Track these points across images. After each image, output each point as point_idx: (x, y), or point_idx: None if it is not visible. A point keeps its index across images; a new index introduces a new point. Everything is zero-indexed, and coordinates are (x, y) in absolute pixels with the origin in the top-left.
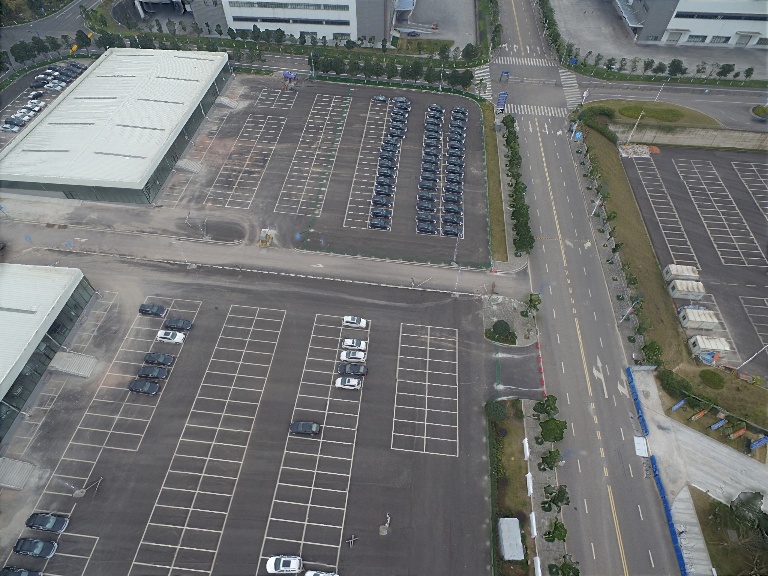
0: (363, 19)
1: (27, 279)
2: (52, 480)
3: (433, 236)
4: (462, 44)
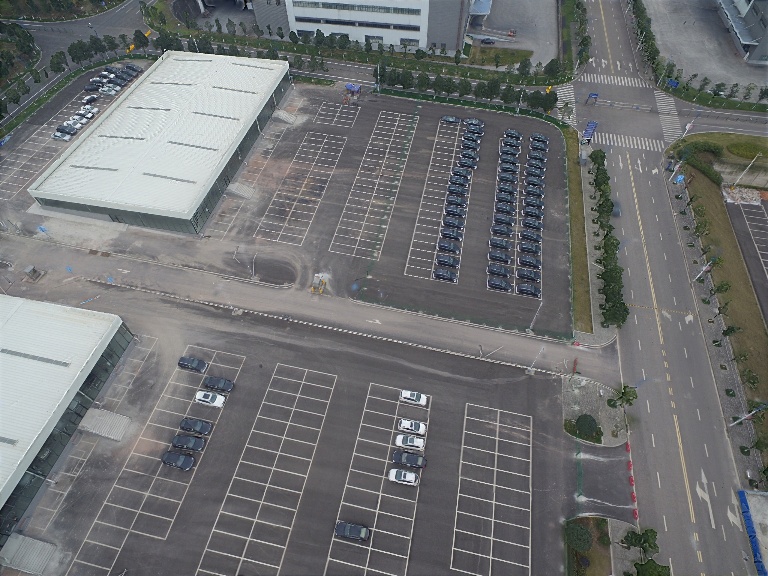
0: (435, 25)
1: (63, 323)
2: (73, 567)
3: (506, 294)
4: (542, 55)
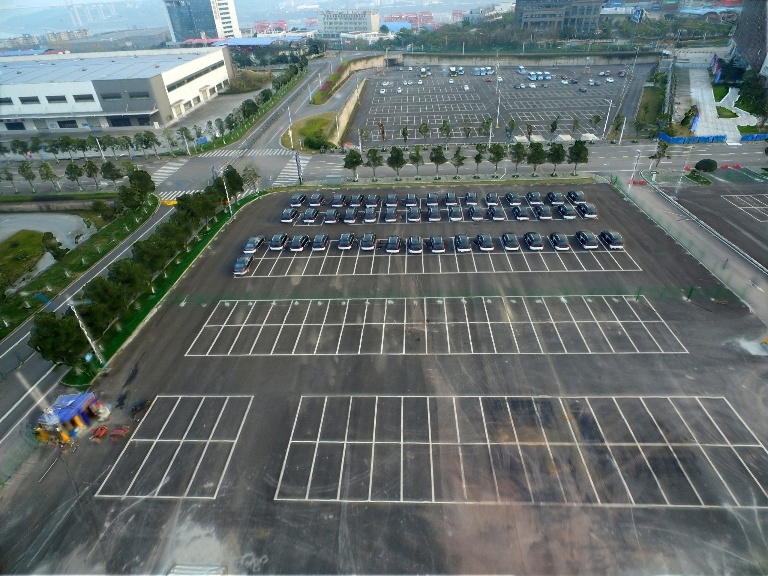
0: None
1: None
2: None
3: None
4: (42, 224)
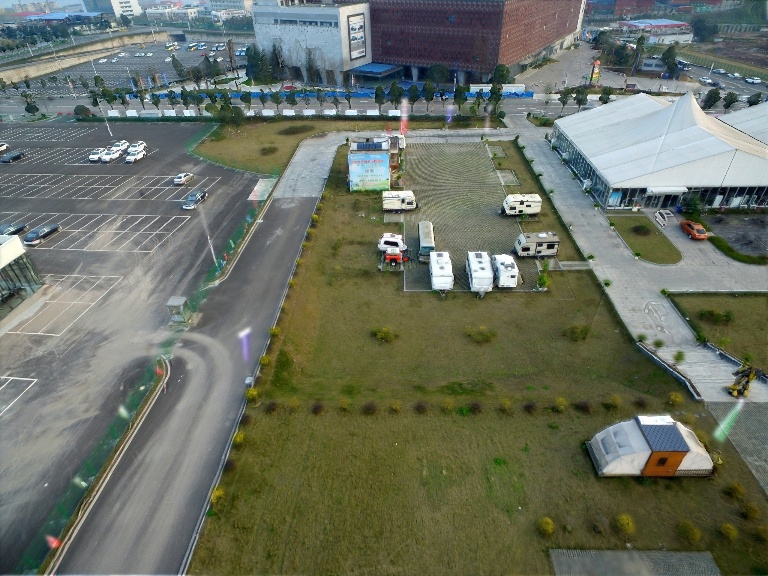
0: None
1: None
2: None
3: None
4: None
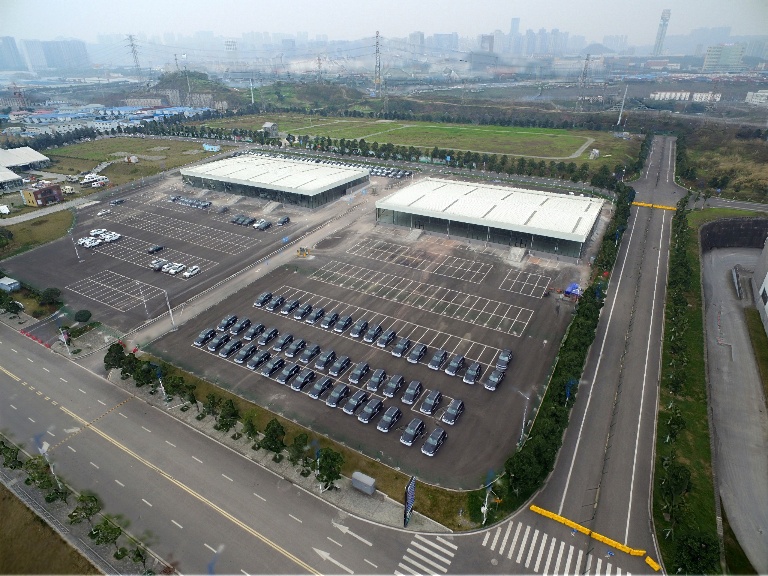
0: None
1: None
2: None
3: None
4: None
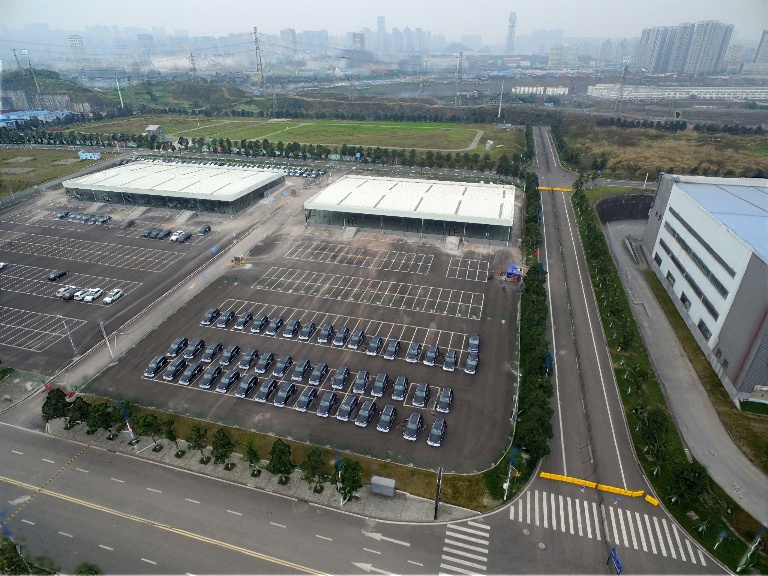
0: (731, 325)
1: None
2: None
3: None
4: None
